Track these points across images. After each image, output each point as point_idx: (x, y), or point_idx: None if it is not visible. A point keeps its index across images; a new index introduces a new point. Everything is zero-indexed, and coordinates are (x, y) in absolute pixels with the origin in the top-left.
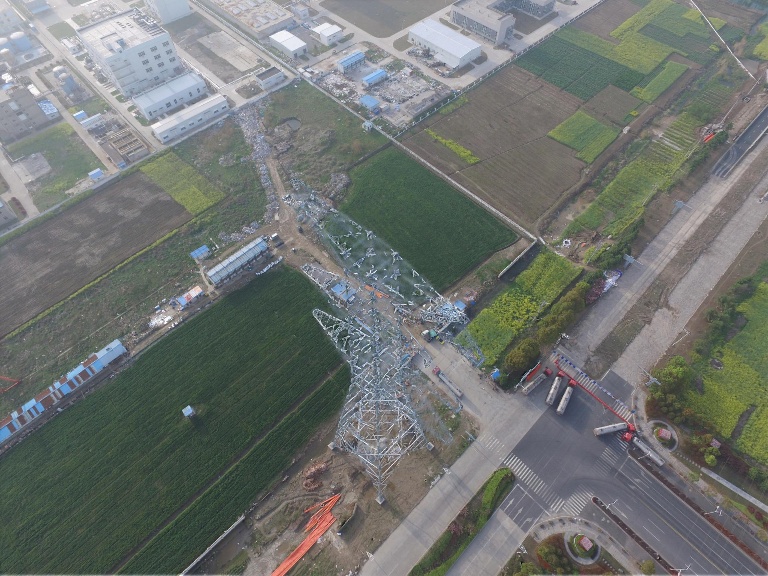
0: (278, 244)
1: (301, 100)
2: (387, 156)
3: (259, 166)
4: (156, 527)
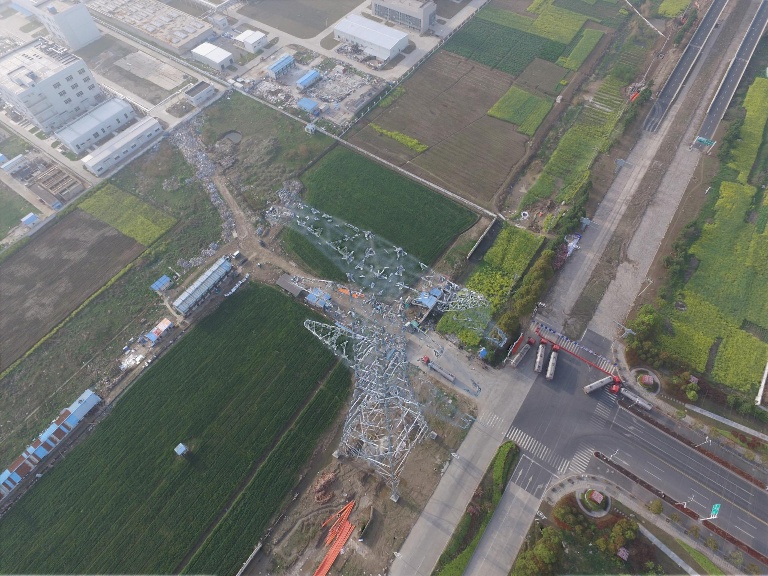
0: (242, 262)
1: (237, 112)
2: (336, 156)
3: (206, 185)
4: (170, 575)
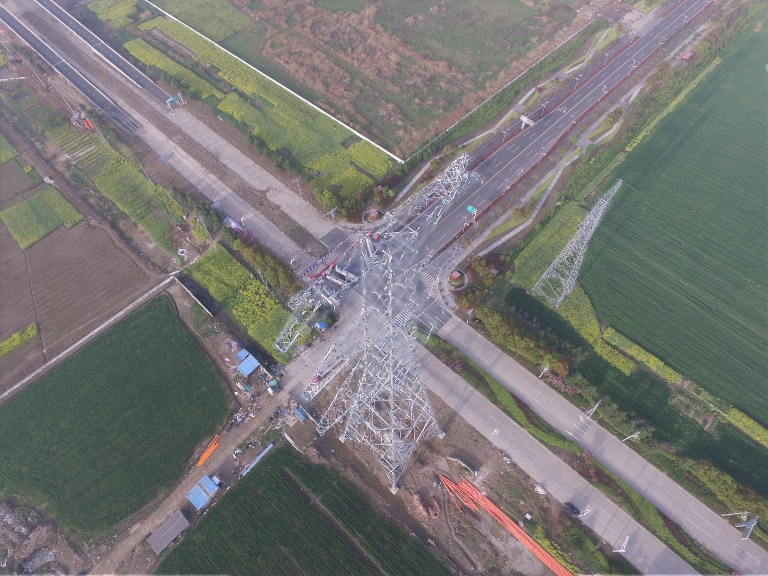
0: None
1: None
2: None
3: None
4: None
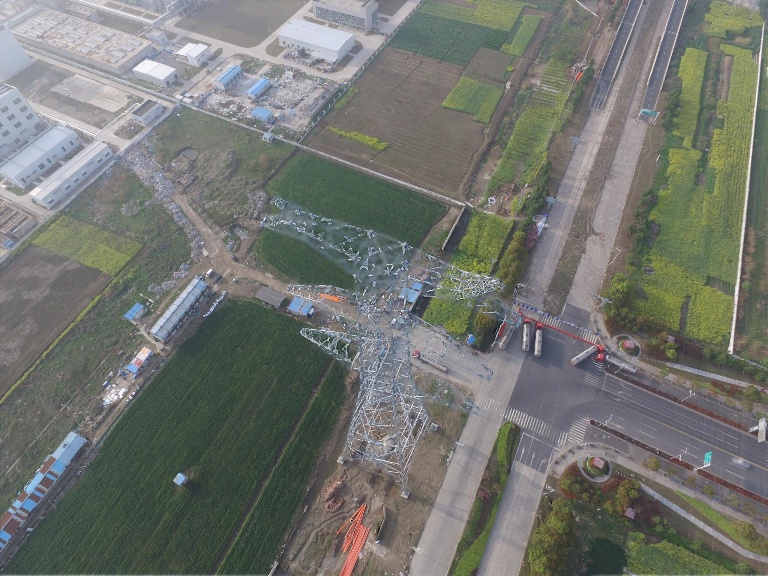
0: (216, 279)
1: (189, 128)
2: (298, 163)
3: (168, 206)
4: None
